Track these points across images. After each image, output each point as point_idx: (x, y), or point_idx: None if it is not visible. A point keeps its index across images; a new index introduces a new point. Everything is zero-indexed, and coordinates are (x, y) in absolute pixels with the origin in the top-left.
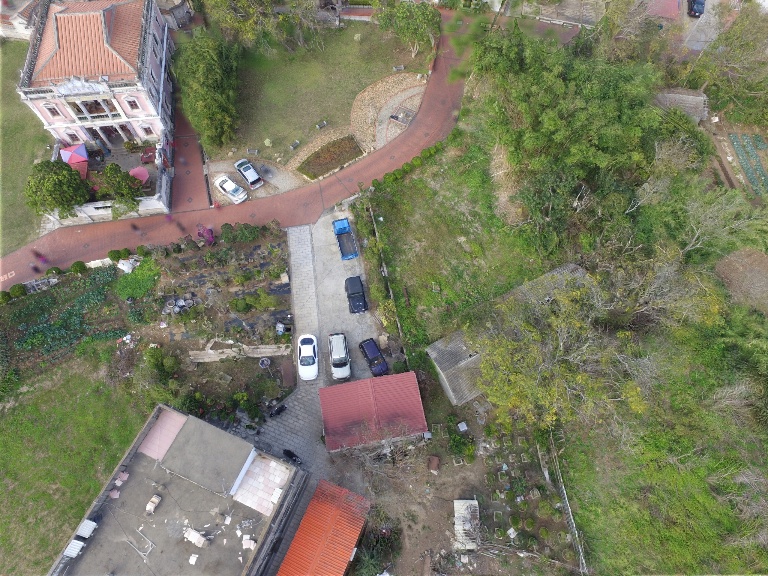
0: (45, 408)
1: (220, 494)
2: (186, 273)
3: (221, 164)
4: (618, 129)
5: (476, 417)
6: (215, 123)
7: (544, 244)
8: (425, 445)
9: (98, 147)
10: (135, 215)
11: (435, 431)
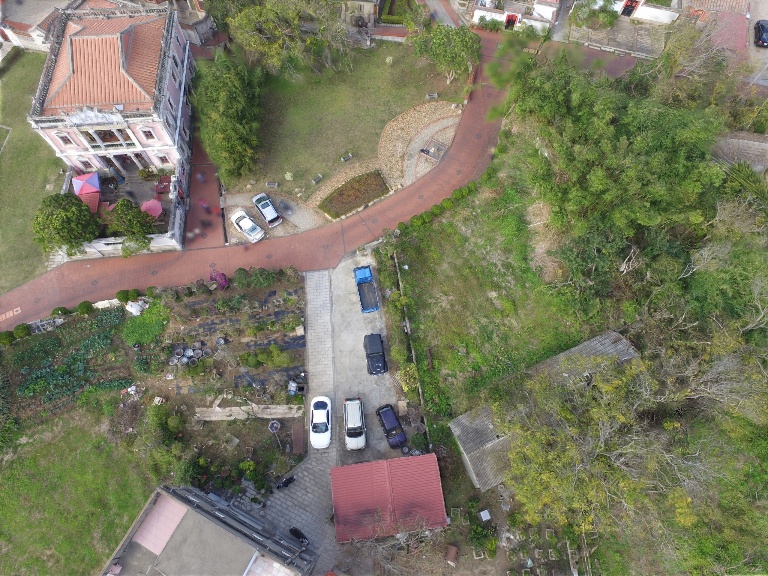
0: (44, 463)
1: None
2: (196, 319)
3: (239, 197)
4: (675, 183)
5: (500, 502)
6: (233, 156)
7: (584, 308)
8: (443, 531)
9: (112, 174)
10: (146, 251)
11: (455, 516)
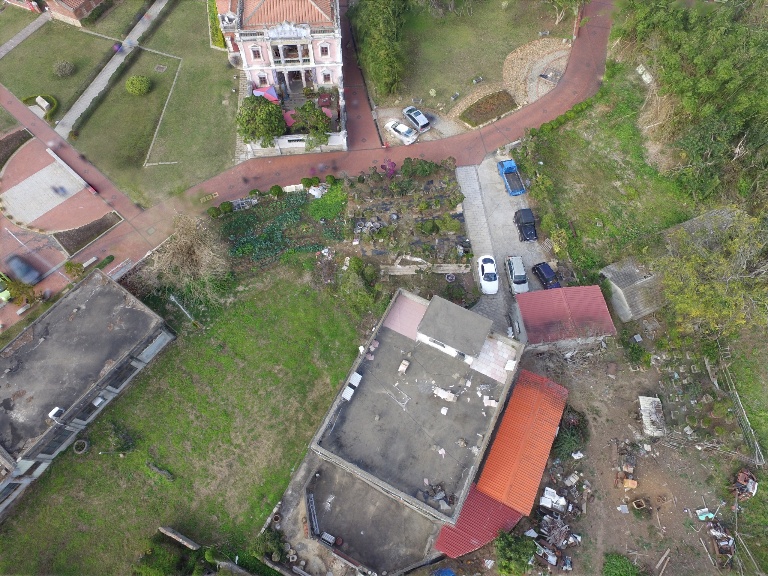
0: (261, 304)
1: (471, 356)
2: (370, 200)
3: (389, 111)
4: None
5: (645, 334)
6: (393, 71)
7: (701, 188)
8: (601, 354)
9: (280, 91)
10: (318, 150)
11: (610, 342)
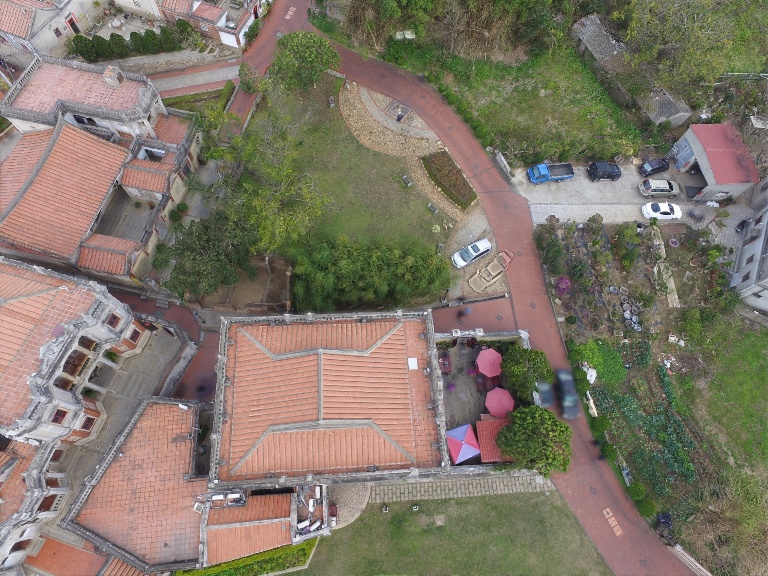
0: (744, 434)
1: None
2: None
3: (452, 285)
4: None
5: None
6: None
7: None
8: None
9: None
10: None
11: None
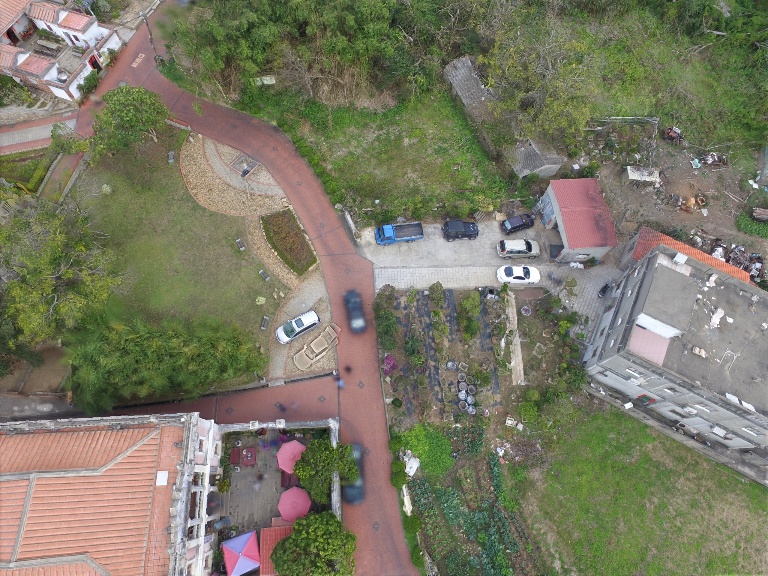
0: (576, 533)
1: None
2: None
3: (274, 362)
4: None
5: None
6: None
7: None
8: None
9: None
10: None
11: None
